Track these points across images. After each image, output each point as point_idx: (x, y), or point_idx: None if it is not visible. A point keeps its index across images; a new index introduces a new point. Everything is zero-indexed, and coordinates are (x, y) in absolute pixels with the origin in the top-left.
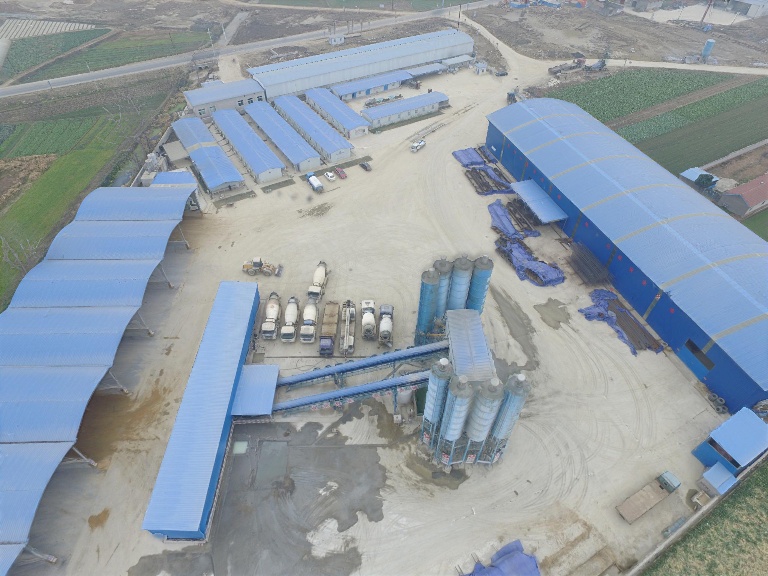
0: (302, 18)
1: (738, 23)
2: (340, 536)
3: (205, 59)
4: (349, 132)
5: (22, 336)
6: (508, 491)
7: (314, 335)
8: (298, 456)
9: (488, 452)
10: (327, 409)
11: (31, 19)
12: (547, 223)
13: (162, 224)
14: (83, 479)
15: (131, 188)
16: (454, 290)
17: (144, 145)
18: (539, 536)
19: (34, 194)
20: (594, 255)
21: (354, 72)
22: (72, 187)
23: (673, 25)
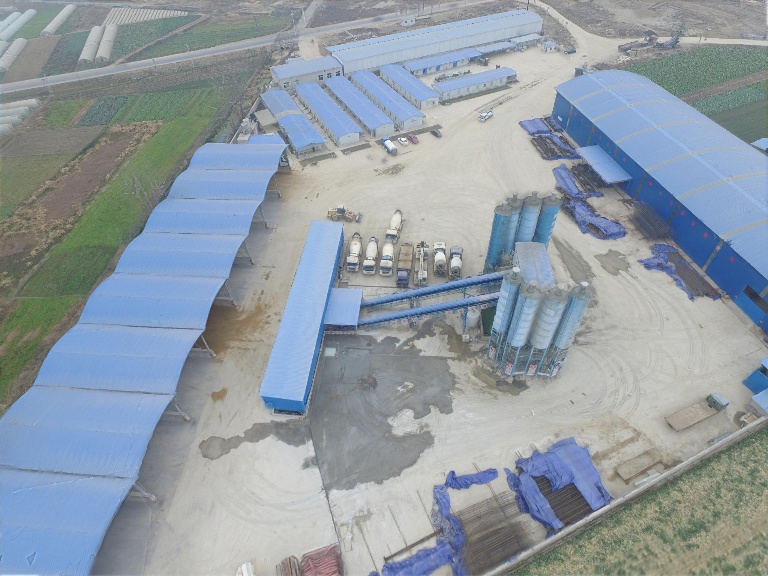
0: (374, 3)
1: None
2: (416, 422)
3: (286, 40)
4: (421, 103)
5: (157, 252)
6: (565, 400)
7: (392, 269)
8: (379, 361)
9: (548, 364)
10: (403, 328)
11: (133, 8)
12: (610, 185)
13: (261, 173)
14: (205, 366)
15: (233, 144)
16: (523, 226)
17: (236, 114)
18: (592, 436)
19: (147, 152)
20: (656, 212)
21: (425, 50)
22: (178, 147)
23: (755, 3)
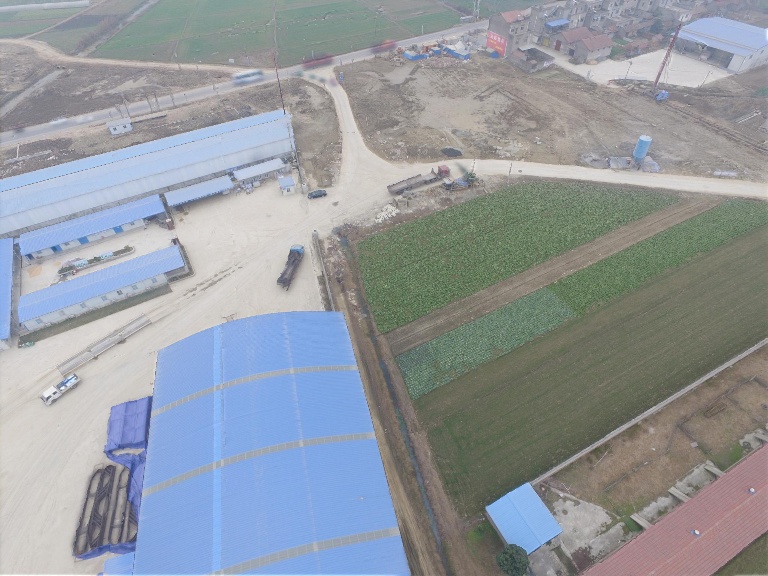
0: (118, 82)
1: (712, 83)
2: None
3: None
4: None
5: None
6: None
7: None
8: None
9: None
10: None
11: None
12: None
13: None
14: None
15: None
16: None
17: None
18: None
19: None
20: None
21: (76, 203)
22: None
23: (616, 88)
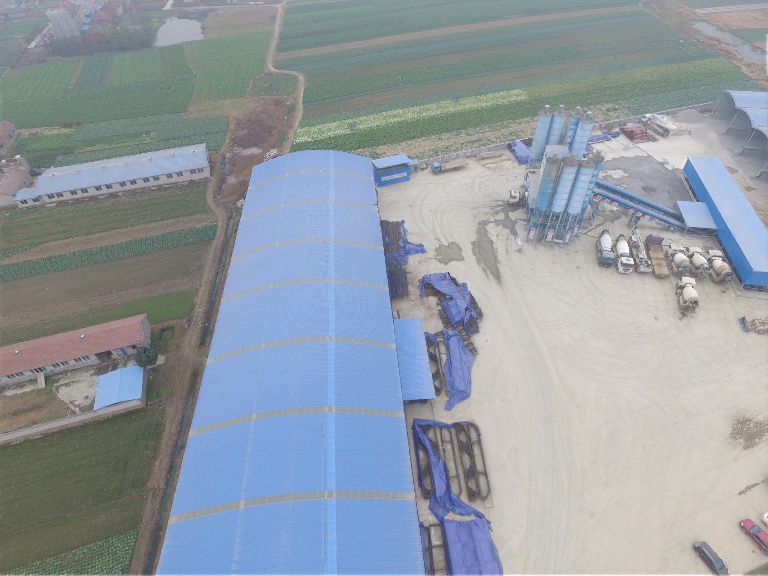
0: None
1: None
2: None
3: None
4: None
5: None
6: None
7: None
8: None
9: None
10: None
11: None
12: None
13: None
14: None
15: None
16: None
17: None
18: (509, 166)
19: None
20: (388, 277)
21: None
22: None
23: None
